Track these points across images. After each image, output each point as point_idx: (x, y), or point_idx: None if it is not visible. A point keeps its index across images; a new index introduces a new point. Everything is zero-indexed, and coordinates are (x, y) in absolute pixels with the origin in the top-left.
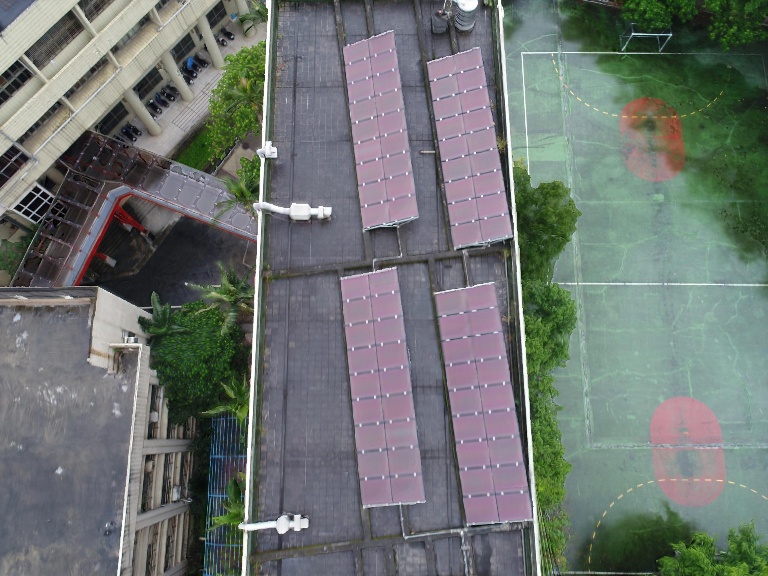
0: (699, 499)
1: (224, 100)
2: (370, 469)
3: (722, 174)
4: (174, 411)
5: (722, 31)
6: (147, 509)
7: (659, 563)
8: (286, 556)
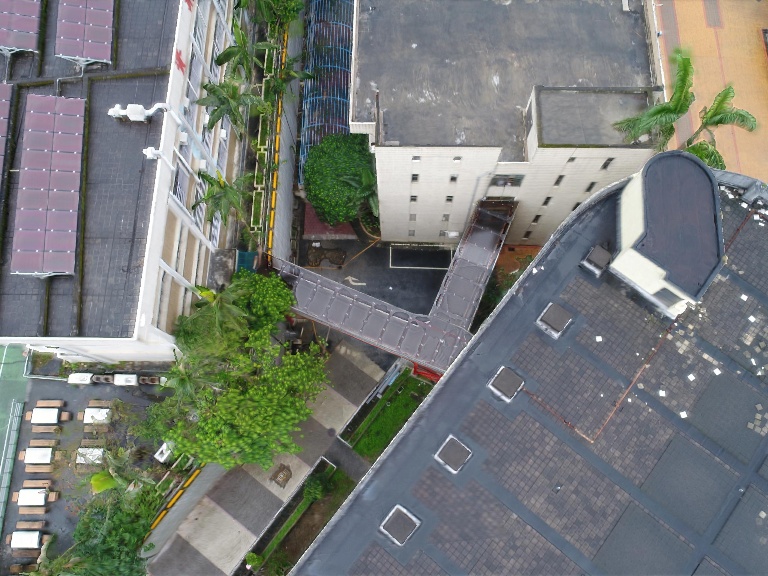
0: None
1: None
2: None
3: None
4: None
5: None
6: None
7: None
8: None
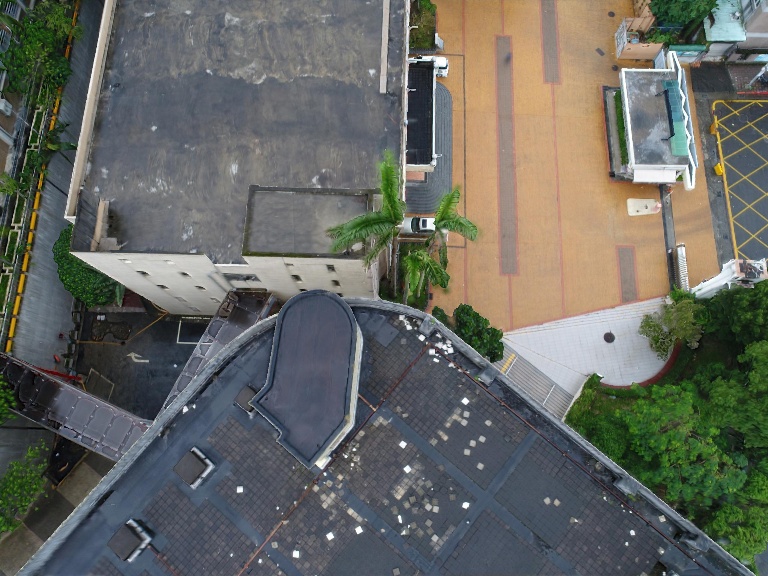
0: None
1: None
2: None
3: None
4: None
5: None
6: None
7: None
8: None
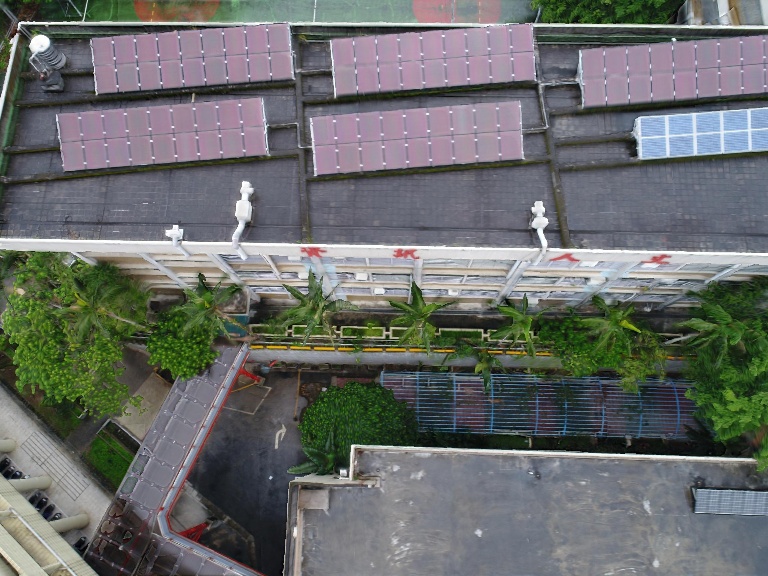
0: (495, 4)
1: None
2: (492, 150)
3: None
4: None
5: None
6: None
7: None
8: (566, 223)
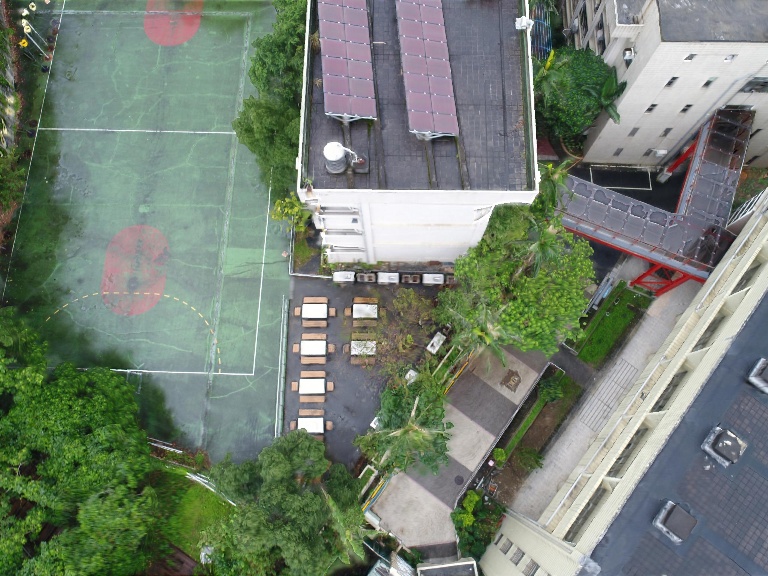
0: None
1: None
2: None
3: (76, 231)
4: None
5: (34, 344)
6: None
7: None
8: None
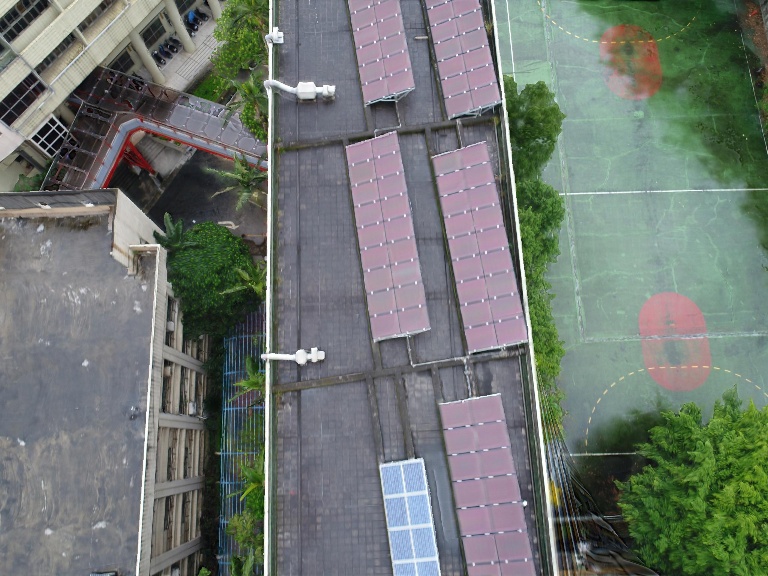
0: (687, 384)
1: (228, 29)
2: (379, 307)
3: (697, 91)
4: (188, 326)
5: None
6: (167, 412)
7: (650, 432)
8: (305, 385)
